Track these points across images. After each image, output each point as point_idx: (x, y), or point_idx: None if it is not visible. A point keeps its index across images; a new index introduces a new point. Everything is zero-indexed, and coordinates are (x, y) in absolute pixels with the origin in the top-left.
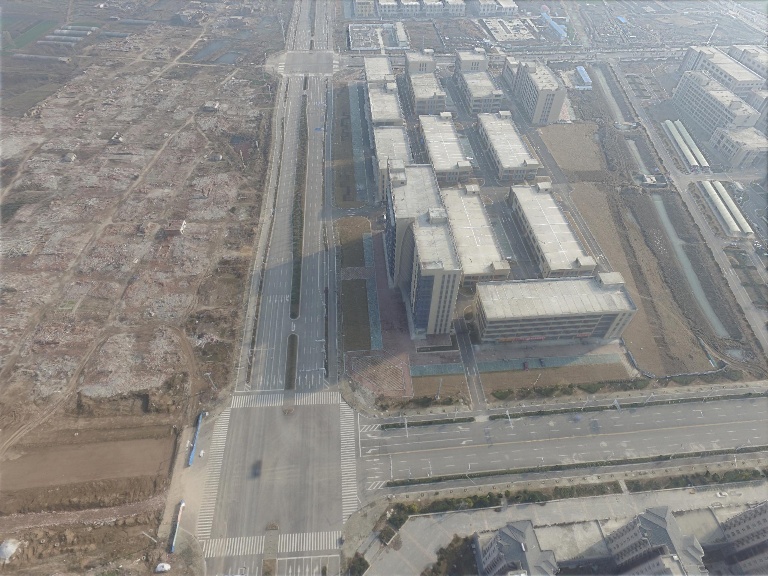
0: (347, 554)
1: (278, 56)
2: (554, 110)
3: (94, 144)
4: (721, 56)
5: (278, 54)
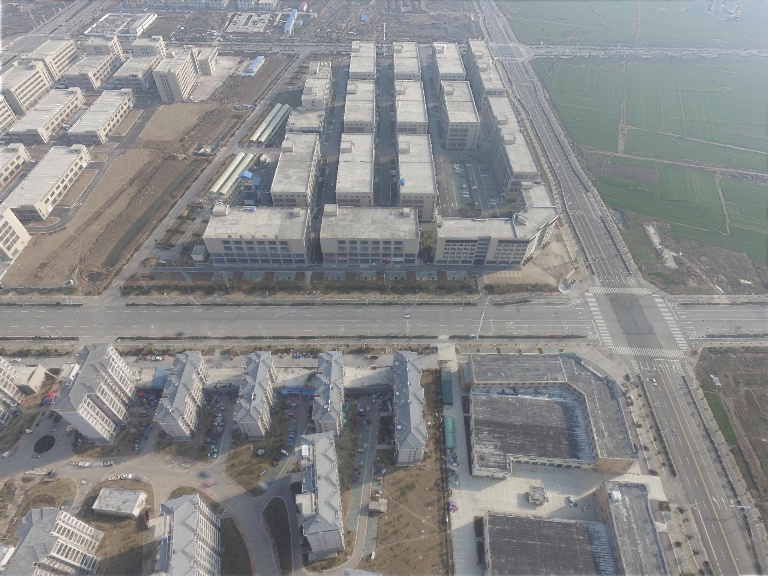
0: None
1: (15, 38)
2: (175, 90)
3: None
4: (369, 51)
5: (17, 36)
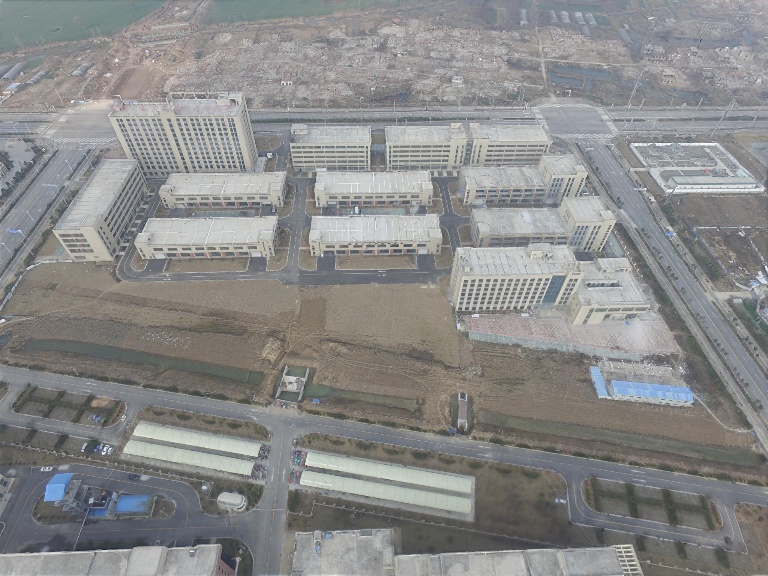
0: (37, 139)
1: (583, 103)
2: None
3: (395, 50)
4: None
5: (588, 102)
